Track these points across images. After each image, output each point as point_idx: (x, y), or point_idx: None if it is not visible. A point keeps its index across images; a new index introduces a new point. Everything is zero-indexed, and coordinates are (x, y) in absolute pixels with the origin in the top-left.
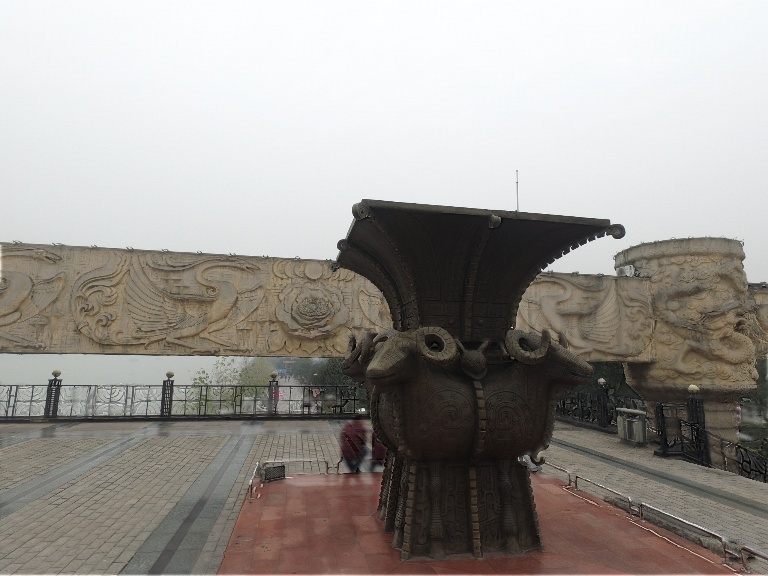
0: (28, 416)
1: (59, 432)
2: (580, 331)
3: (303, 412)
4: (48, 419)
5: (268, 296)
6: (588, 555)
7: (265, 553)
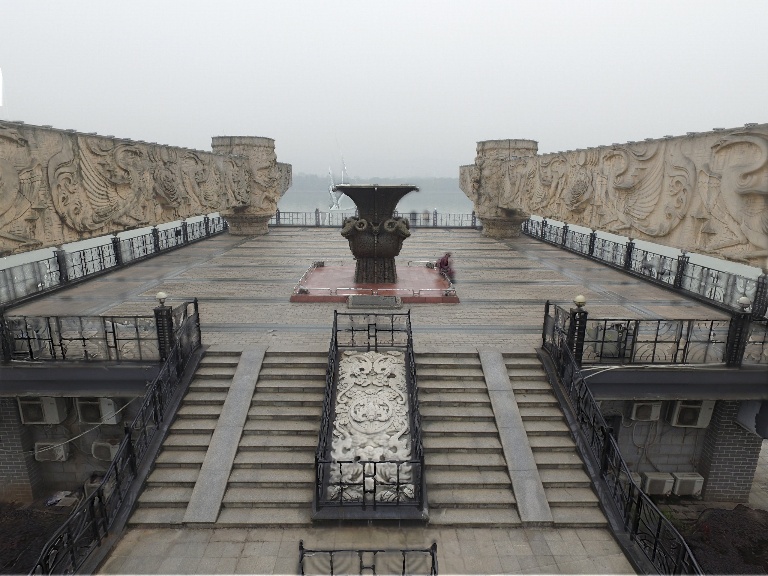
0: (559, 244)
1: (534, 251)
2: (763, 221)
3: (641, 272)
4: None
5: None
6: None
7: None
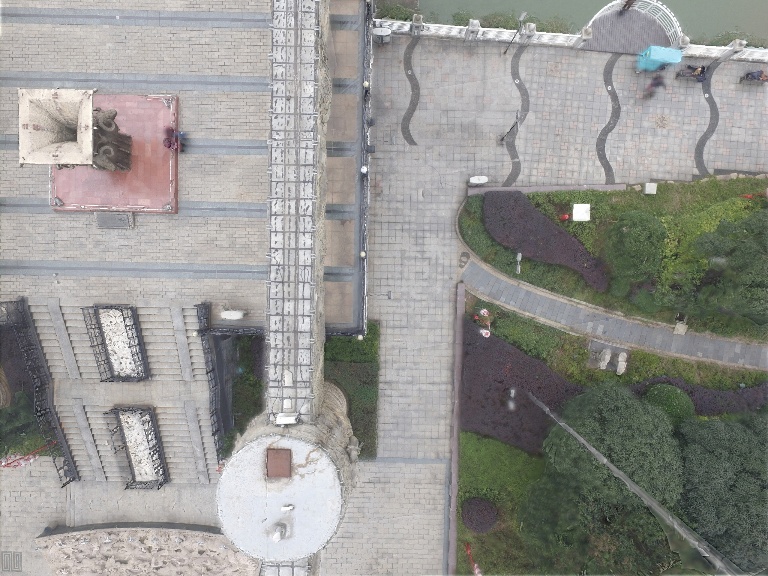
0: None
1: None
2: None
3: None
4: None
5: None
6: (92, 178)
7: (104, 104)
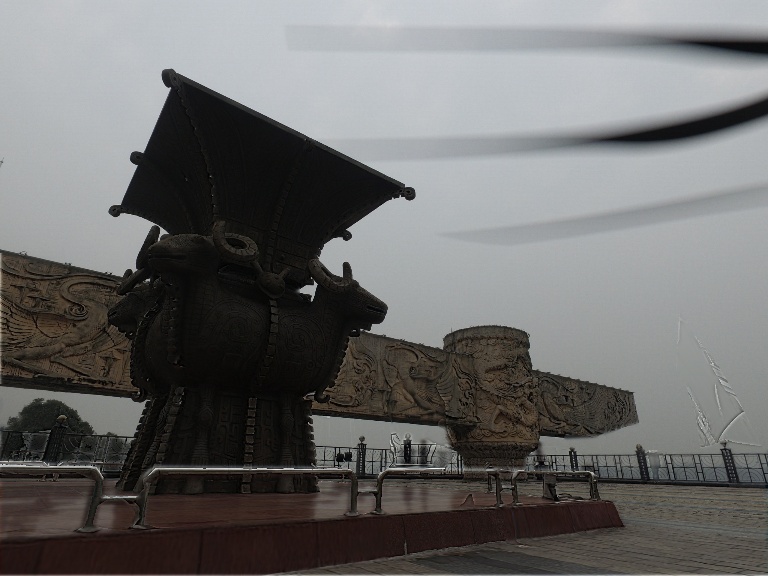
0: None
1: None
2: None
3: None
4: None
5: None
6: None
7: None
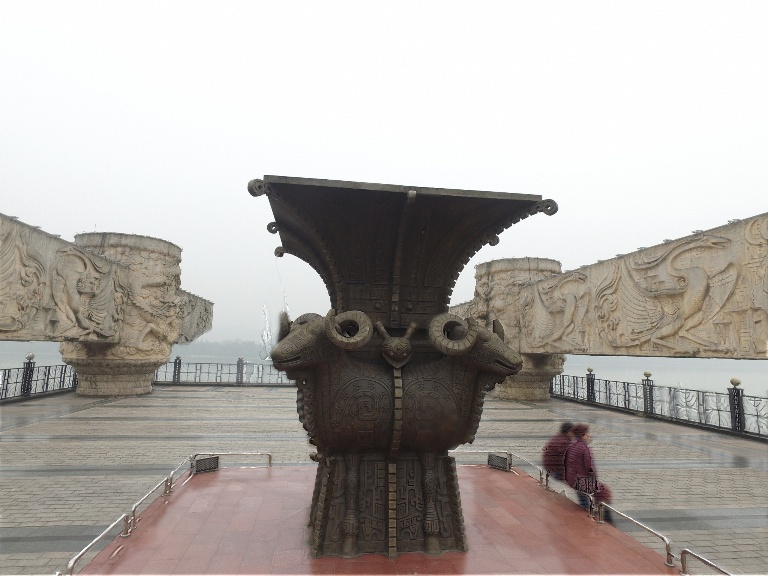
0: (636, 410)
1: (617, 423)
2: None
3: None
4: (645, 415)
5: (745, 274)
6: None
7: None
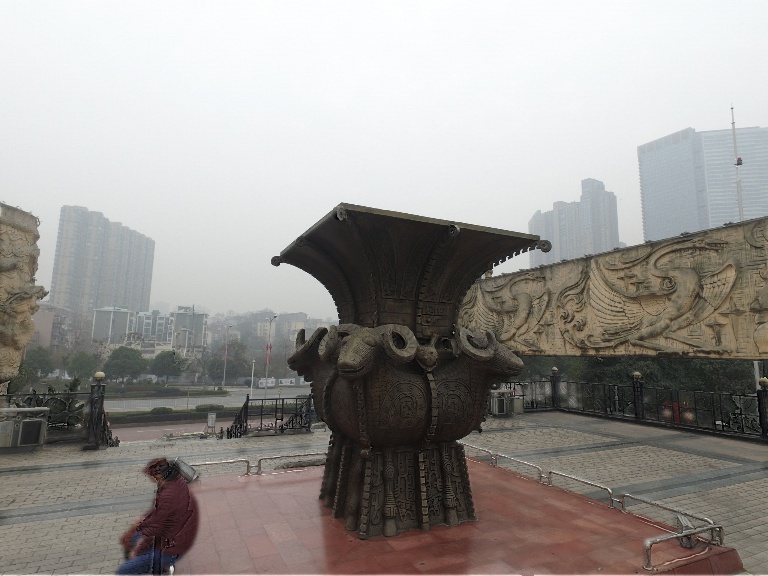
0: None
1: None
2: None
3: None
4: None
5: None
6: None
7: (541, 575)
